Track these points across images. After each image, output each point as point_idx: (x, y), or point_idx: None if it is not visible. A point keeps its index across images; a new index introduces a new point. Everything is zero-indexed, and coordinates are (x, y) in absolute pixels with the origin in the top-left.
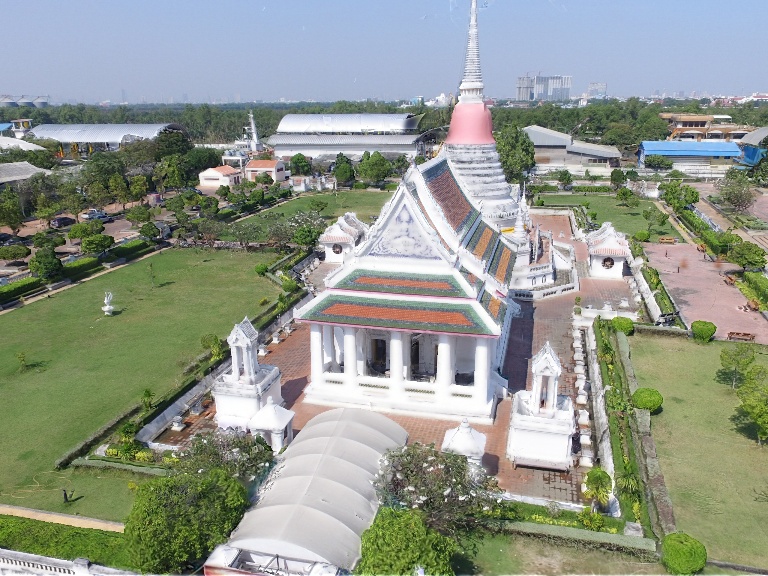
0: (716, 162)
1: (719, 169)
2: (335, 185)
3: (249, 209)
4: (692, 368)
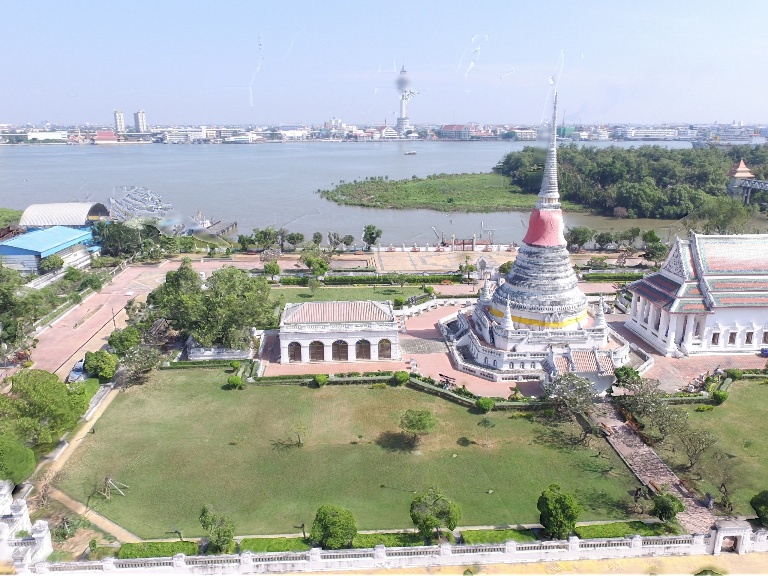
0: None
1: (83, 255)
2: (12, 501)
3: None
4: None
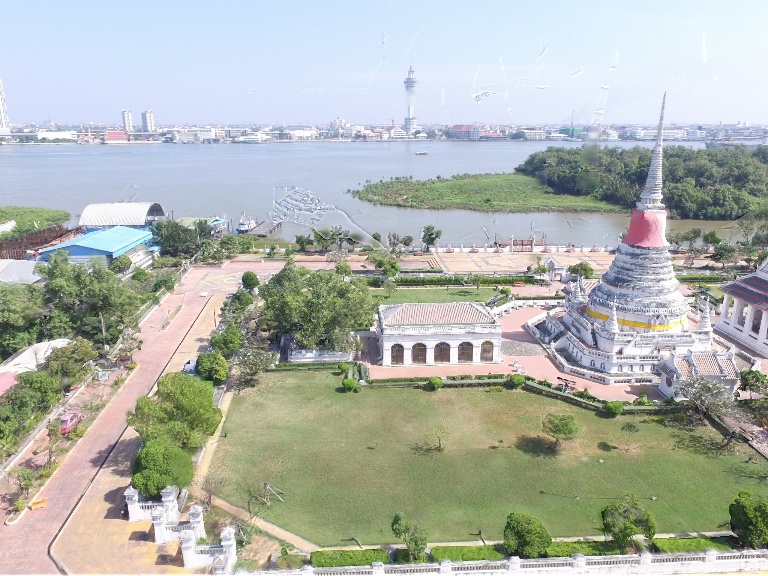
0: (139, 249)
1: (145, 256)
2: (177, 507)
3: None
4: None
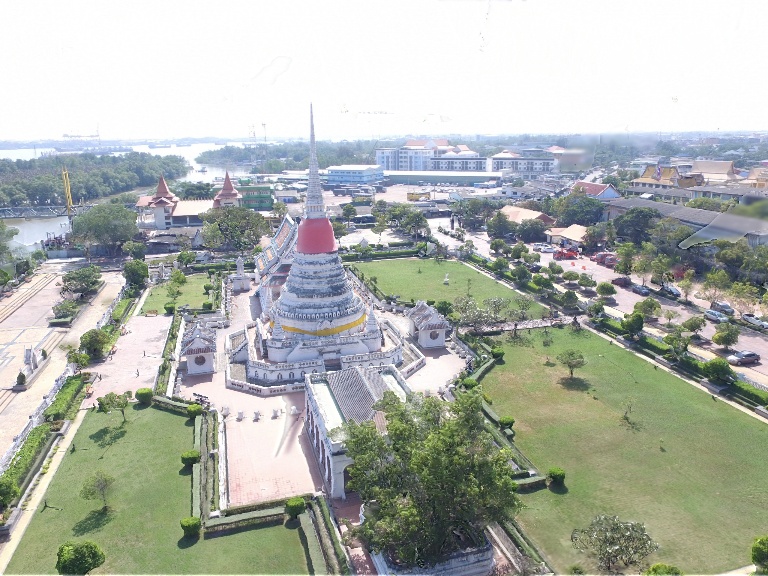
0: None
1: None
2: None
3: (689, 368)
4: (184, 304)
